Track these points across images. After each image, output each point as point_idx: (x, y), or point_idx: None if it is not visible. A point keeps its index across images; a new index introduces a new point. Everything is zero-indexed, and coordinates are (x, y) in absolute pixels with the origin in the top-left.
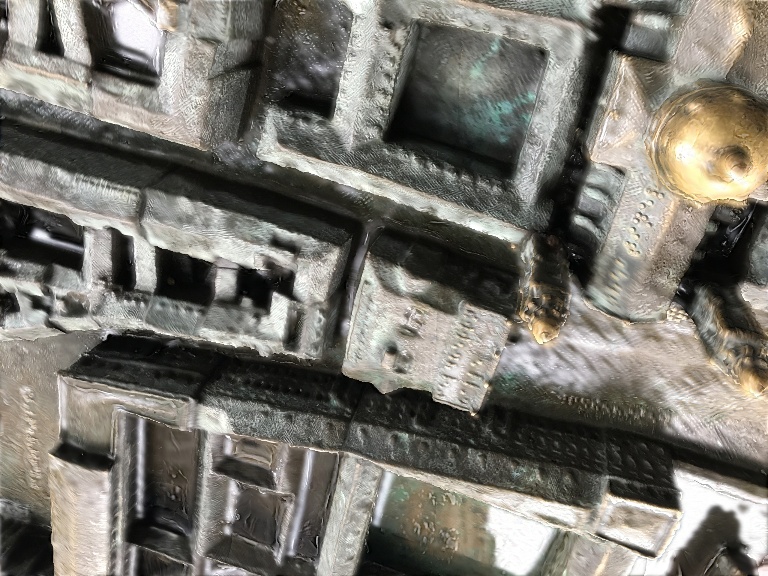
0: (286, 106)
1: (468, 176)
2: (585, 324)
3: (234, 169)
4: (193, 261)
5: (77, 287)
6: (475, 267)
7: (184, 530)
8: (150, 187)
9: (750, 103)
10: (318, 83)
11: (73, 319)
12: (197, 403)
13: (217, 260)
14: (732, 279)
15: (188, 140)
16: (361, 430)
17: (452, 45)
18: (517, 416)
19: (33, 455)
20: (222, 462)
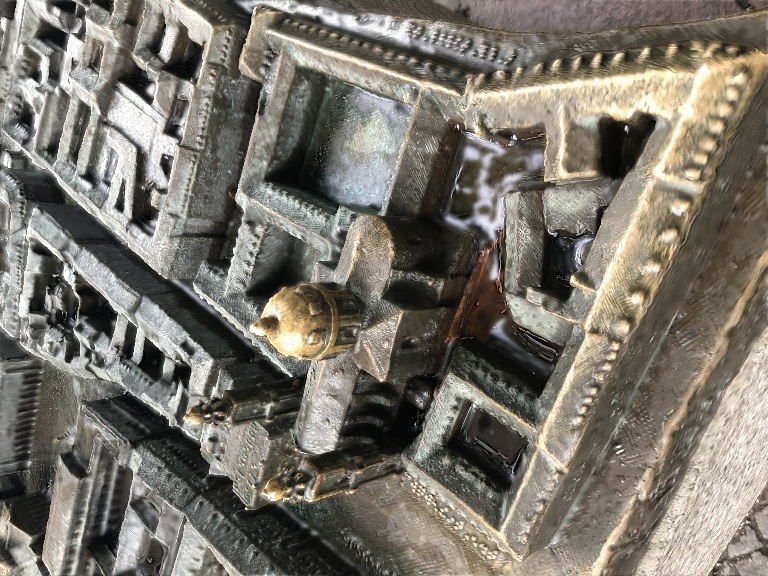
0: (215, 262)
1: None
2: None
3: (205, 299)
4: None
5: (105, 348)
6: None
7: None
8: (147, 295)
9: (299, 294)
10: None
11: (98, 368)
12: (132, 447)
13: (165, 351)
14: (398, 450)
15: (156, 269)
16: (200, 502)
17: None
18: (314, 543)
19: None
20: (138, 501)
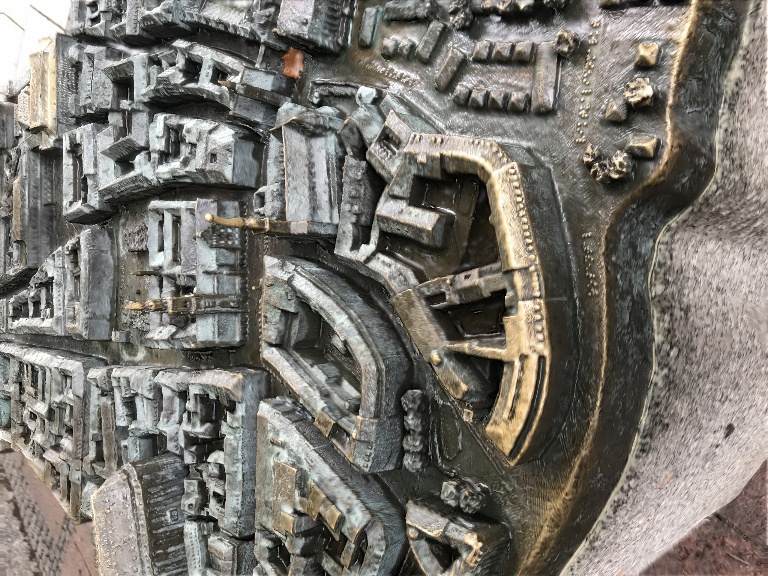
0: None
1: None
2: None
3: None
4: None
5: None
6: None
7: None
8: None
9: None
10: None
11: None
12: None
13: None
14: None
15: (15, 351)
16: None
17: None
18: None
19: None
20: None
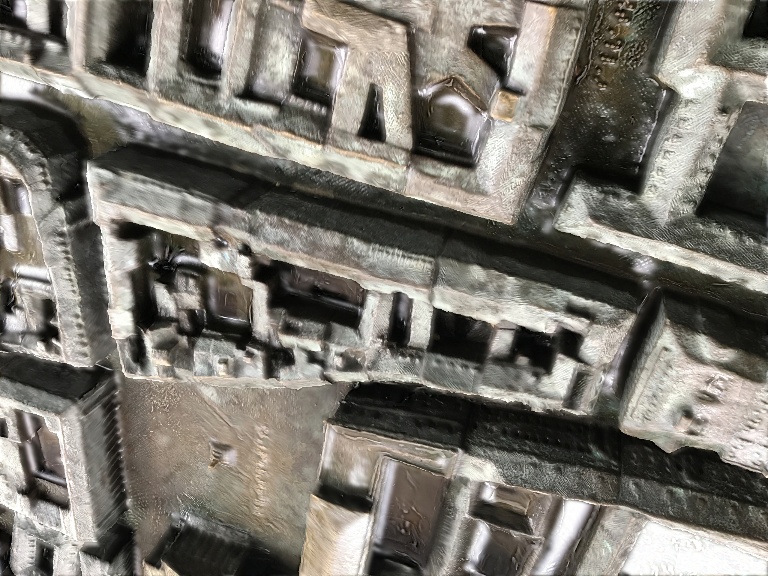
0: (590, 181)
1: None
2: None
3: (507, 232)
4: (456, 317)
5: (355, 344)
6: (762, 329)
7: (419, 564)
8: (442, 255)
9: None
10: (608, 153)
11: (347, 373)
12: (463, 453)
13: (500, 322)
14: None
15: (500, 217)
16: (634, 484)
17: (761, 117)
18: None
19: (260, 485)
20: (477, 506)
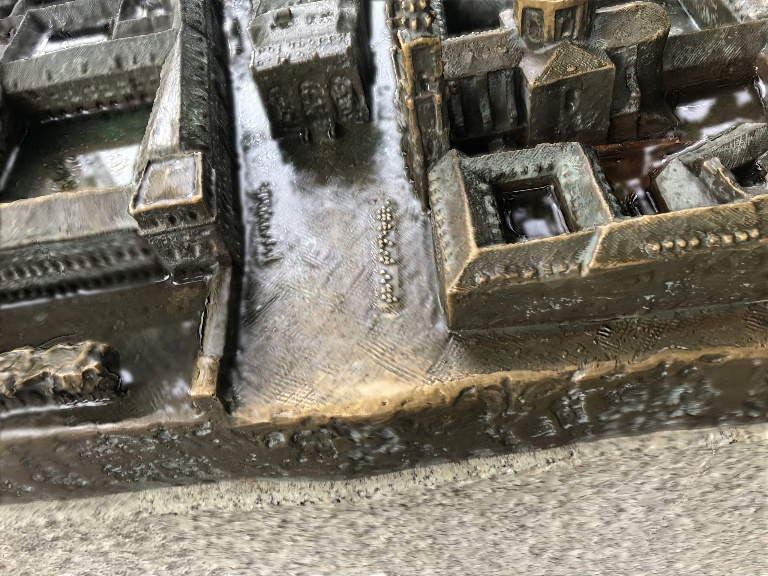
0: None
1: (443, 24)
2: (345, 172)
3: None
4: None
5: None
6: None
7: None
8: None
9: None
10: None
11: None
12: None
13: None
14: None
15: None
16: None
17: None
18: None
19: None
20: None
